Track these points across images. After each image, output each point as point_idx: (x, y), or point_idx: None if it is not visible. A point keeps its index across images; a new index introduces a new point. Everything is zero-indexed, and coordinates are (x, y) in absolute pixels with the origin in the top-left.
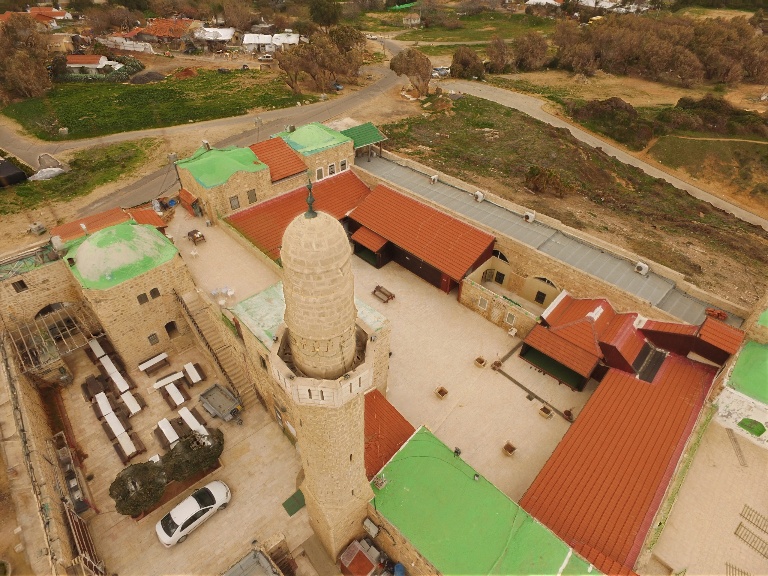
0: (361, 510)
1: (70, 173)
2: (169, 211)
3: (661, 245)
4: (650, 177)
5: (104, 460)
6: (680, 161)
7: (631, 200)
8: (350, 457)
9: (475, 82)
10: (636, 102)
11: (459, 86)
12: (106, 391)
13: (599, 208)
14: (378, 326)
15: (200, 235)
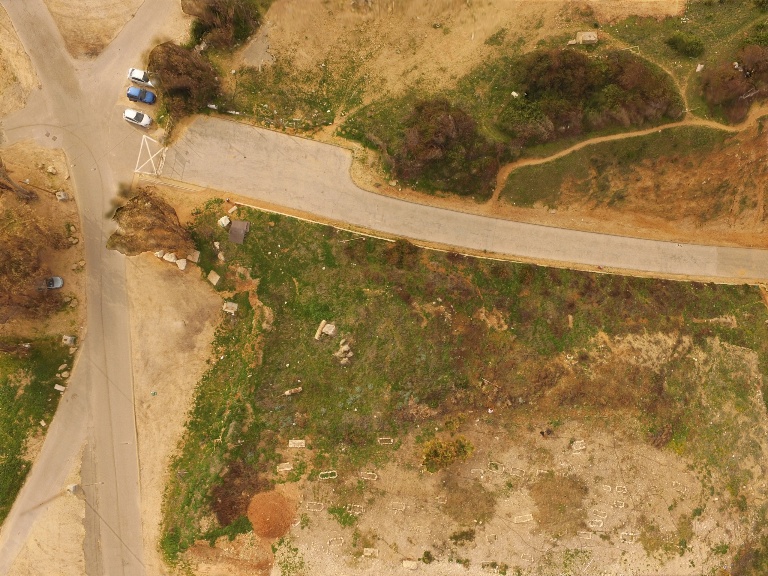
0: None
1: None
2: None
3: (554, 477)
4: (514, 273)
5: None
6: (536, 197)
7: (511, 367)
8: None
9: (219, 119)
10: (457, 51)
11: (207, 155)
12: None
13: (494, 439)
14: None
15: None
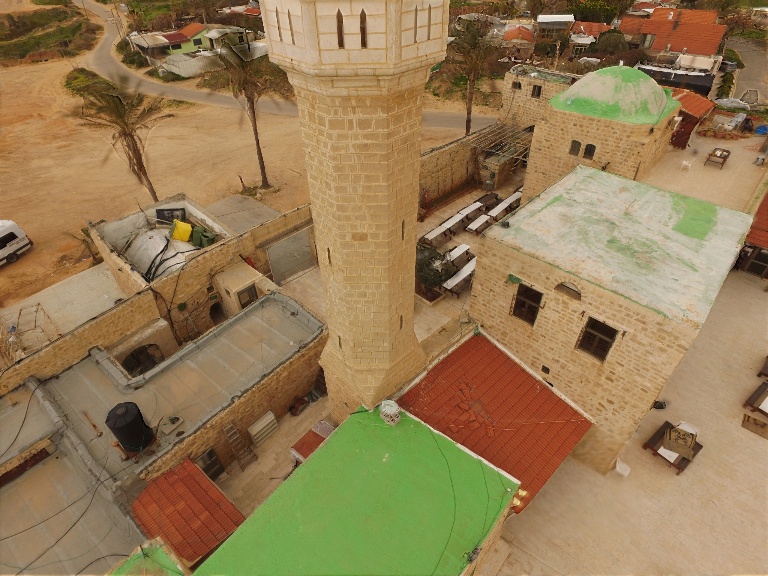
0: (356, 404)
1: (750, 111)
2: (743, 133)
3: None
4: None
5: (421, 231)
6: None
7: None
8: (329, 254)
9: None
10: None
11: None
12: (487, 209)
13: None
14: (668, 311)
15: (722, 155)
